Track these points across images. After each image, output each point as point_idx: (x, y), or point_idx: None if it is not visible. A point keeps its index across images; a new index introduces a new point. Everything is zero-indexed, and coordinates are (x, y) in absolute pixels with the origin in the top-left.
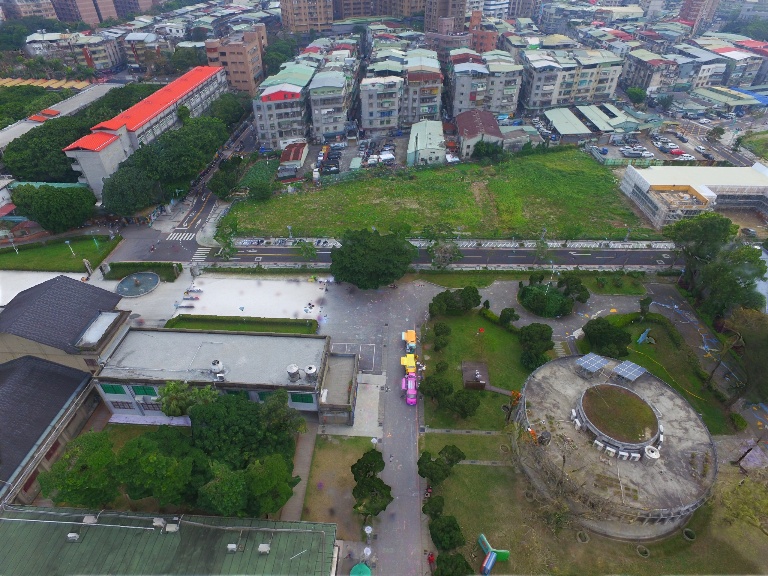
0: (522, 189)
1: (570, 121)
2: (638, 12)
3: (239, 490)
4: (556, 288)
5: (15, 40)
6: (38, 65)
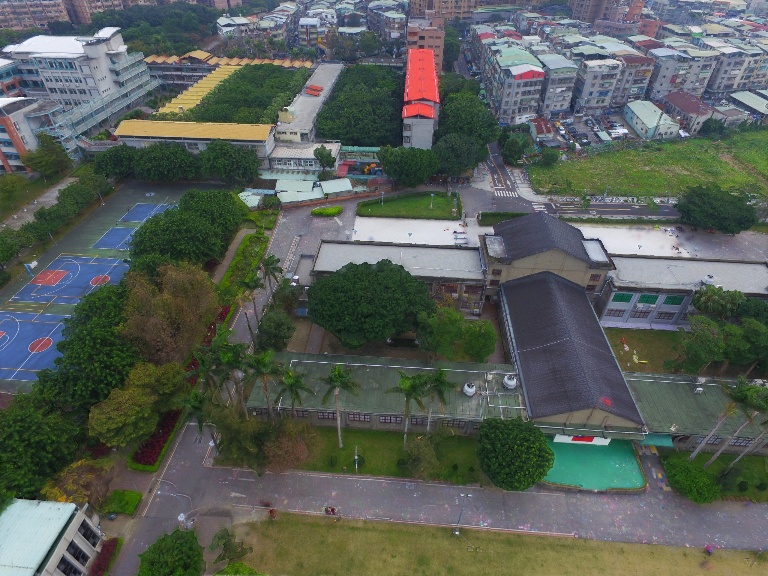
0: None
1: (765, 103)
2: (741, 4)
3: None
4: None
5: (184, 24)
6: (263, 46)
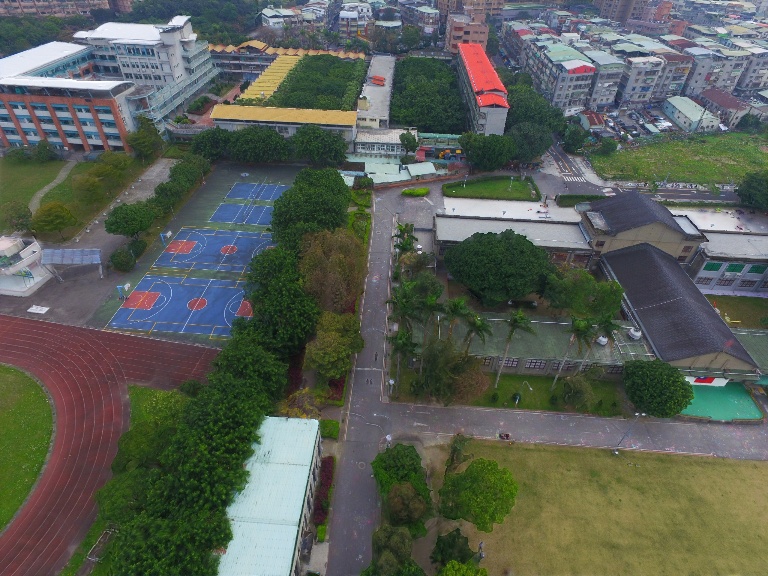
0: None
1: None
2: (751, 7)
3: None
4: None
5: (224, 14)
6: (317, 37)
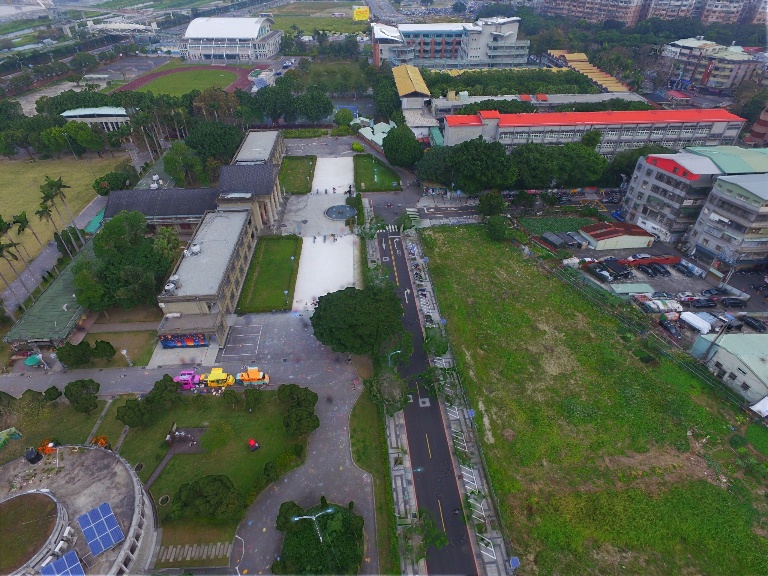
0: (735, 560)
1: None
2: None
3: (74, 271)
4: (347, 568)
5: None
6: None
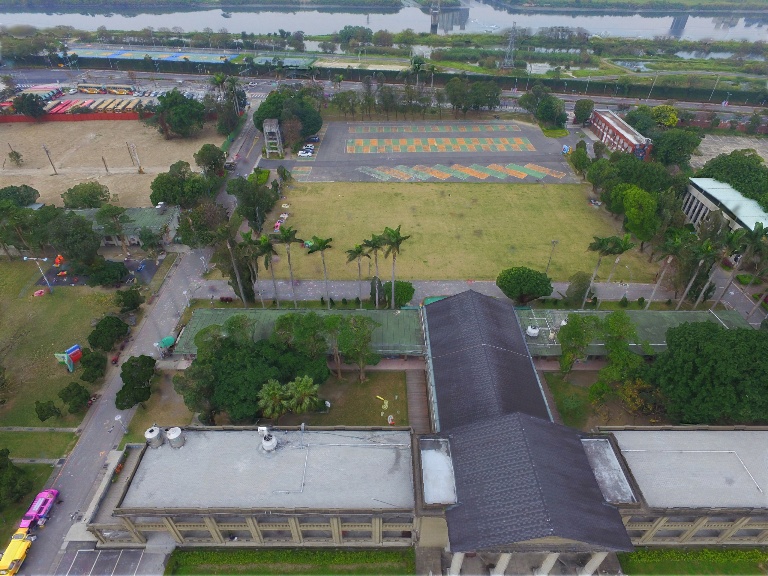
0: None
1: None
2: None
3: None
4: None
5: None
6: None
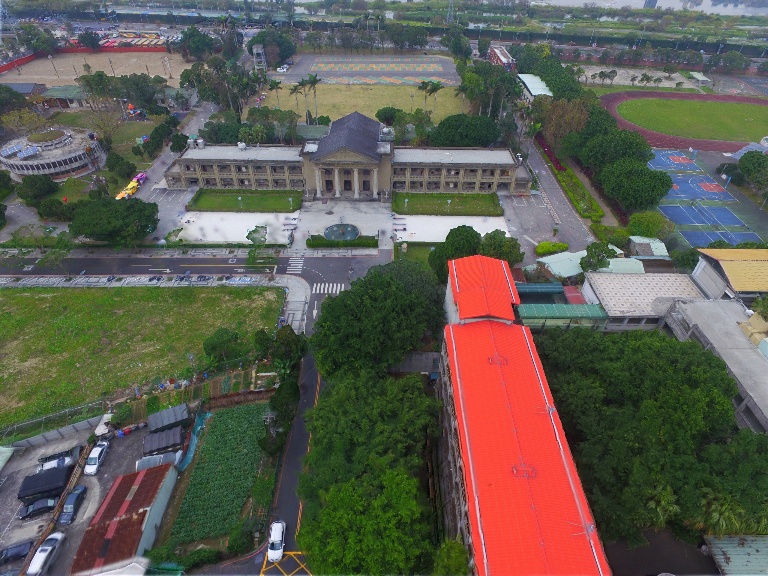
0: None
1: None
2: None
3: None
4: None
5: None
6: None
